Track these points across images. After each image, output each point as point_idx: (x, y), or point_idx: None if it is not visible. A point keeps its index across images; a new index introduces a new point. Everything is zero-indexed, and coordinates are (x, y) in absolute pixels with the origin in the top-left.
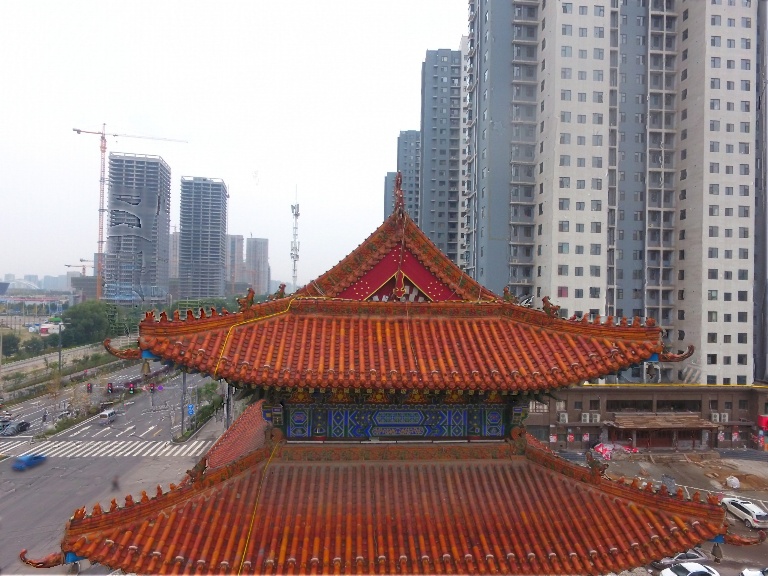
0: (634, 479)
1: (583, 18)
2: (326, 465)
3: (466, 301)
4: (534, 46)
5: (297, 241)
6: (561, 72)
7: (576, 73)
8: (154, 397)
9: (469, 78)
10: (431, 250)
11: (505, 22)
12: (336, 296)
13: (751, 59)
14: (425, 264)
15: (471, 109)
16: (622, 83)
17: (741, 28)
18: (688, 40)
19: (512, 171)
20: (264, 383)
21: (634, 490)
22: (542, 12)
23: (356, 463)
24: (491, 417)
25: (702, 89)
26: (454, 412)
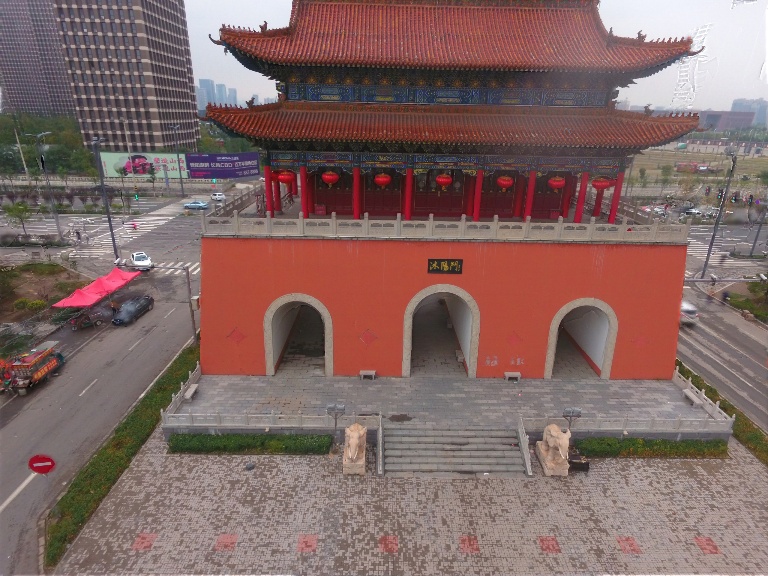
0: None
1: None
2: None
3: None
4: None
5: None
6: None
7: None
8: (751, 211)
9: None
10: None
11: None
12: None
13: None
14: None
15: None
16: None
17: None
18: None
19: None
20: None
21: None
22: None
23: None
24: None
25: None
26: None
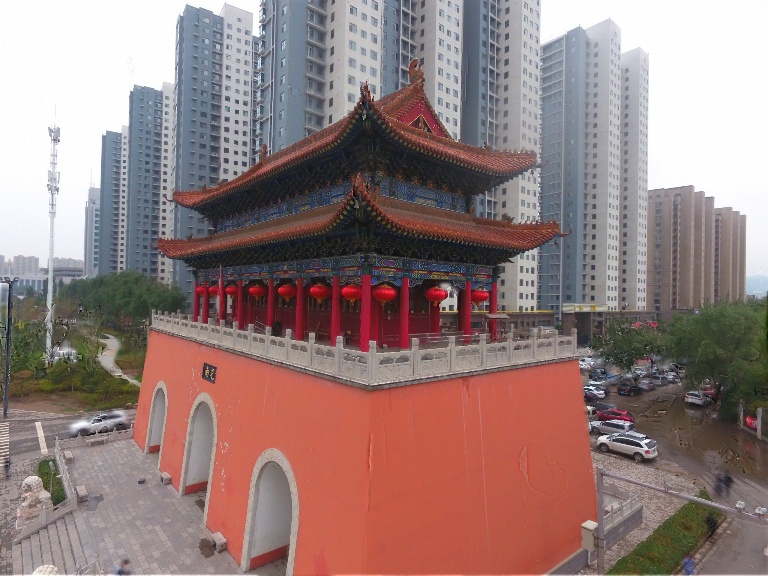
0: (526, 221)
1: (364, 23)
2: (400, 211)
3: (449, 139)
4: (323, 33)
5: (56, 171)
6: (348, 61)
7: (359, 65)
8: None
9: (261, 43)
10: (431, 109)
11: (301, 3)
12: (396, 119)
13: (458, 91)
14: (433, 114)
15: (263, 73)
16: (383, 84)
17: (454, 68)
18: (424, 66)
19: (306, 135)
20: (406, 140)
21: (526, 225)
22: (331, 6)
23: (412, 213)
24: (461, 201)
25: (433, 103)
26: (448, 196)
